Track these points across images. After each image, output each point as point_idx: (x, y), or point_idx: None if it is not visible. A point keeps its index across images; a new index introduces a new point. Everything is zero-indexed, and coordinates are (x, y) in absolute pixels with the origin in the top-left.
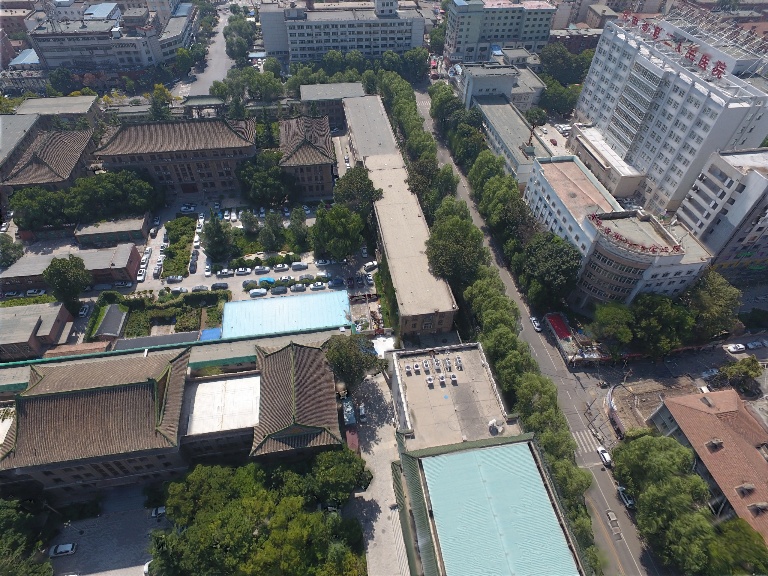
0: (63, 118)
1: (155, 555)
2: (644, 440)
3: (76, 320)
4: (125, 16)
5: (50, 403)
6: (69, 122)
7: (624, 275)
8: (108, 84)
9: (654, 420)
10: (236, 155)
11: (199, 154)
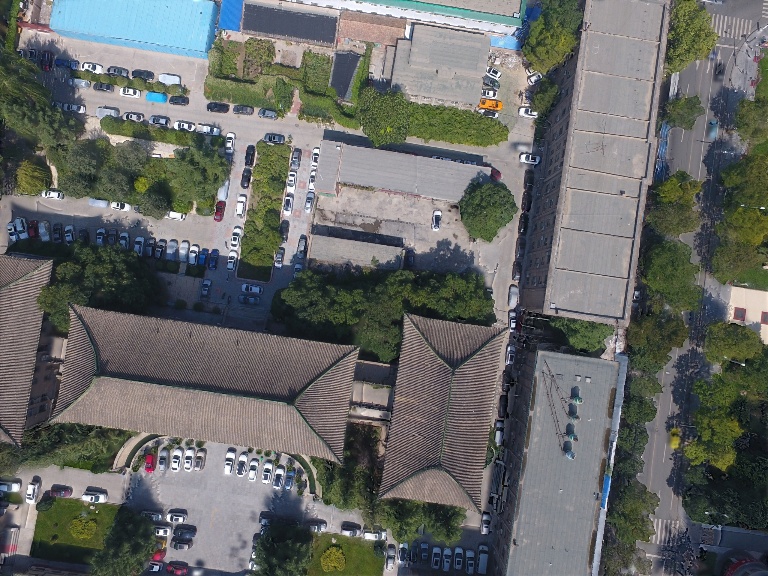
0: None
1: None
2: None
3: None
4: None
5: None
6: None
7: None
8: None
9: None
10: None
11: None
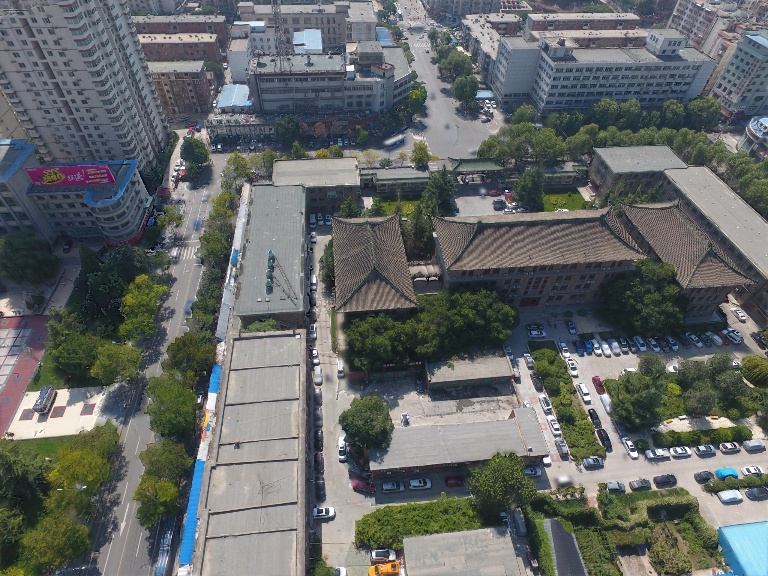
0: (331, 191)
1: None
2: None
3: None
4: (362, 52)
5: None
6: (336, 195)
7: None
8: (333, 133)
9: None
10: (613, 267)
11: (568, 266)
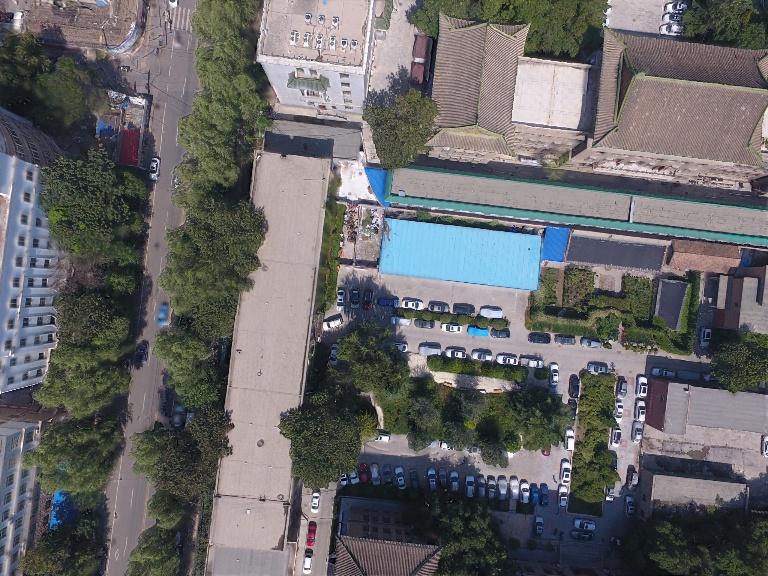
0: None
1: None
2: None
3: (712, 325)
4: None
5: (739, 85)
6: None
7: (6, 117)
8: None
9: None
10: None
11: None
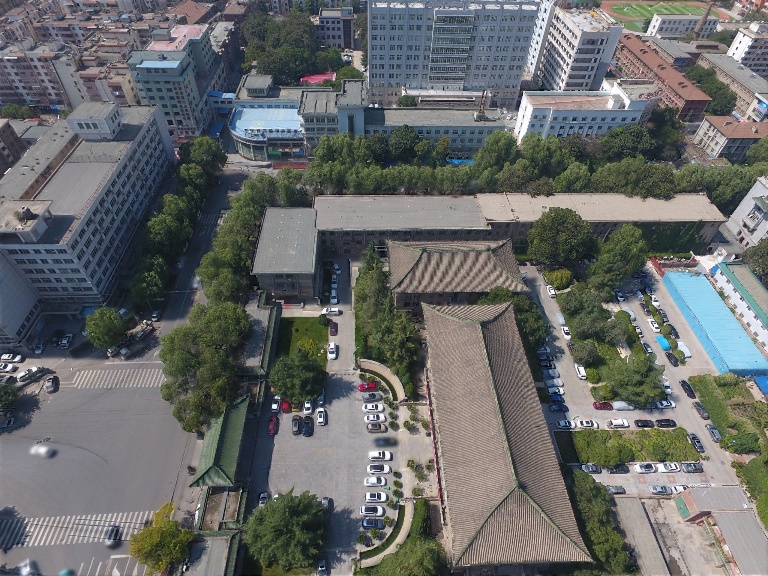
0: None
1: None
2: None
3: None
4: None
5: None
6: None
7: None
8: None
9: None
10: None
11: None
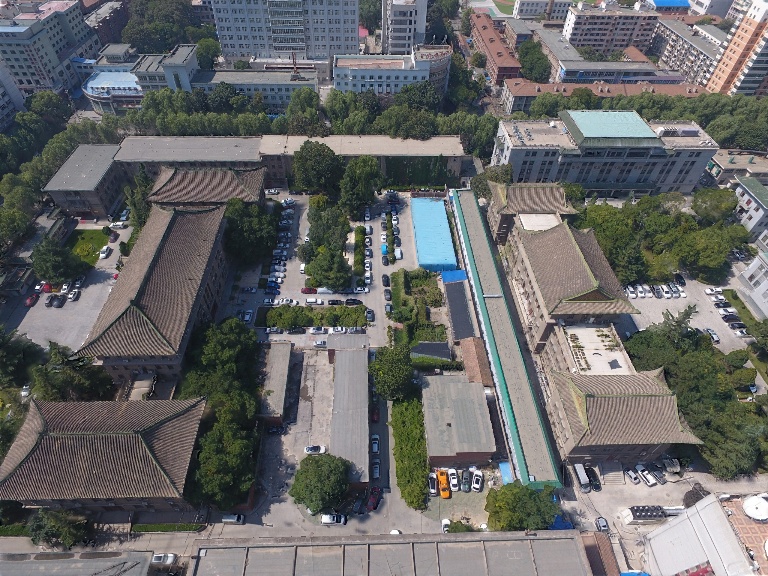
0: None
1: (631, 268)
2: (542, 100)
3: None
4: None
5: None
6: None
7: None
8: None
9: (514, 109)
10: (219, 232)
11: None
